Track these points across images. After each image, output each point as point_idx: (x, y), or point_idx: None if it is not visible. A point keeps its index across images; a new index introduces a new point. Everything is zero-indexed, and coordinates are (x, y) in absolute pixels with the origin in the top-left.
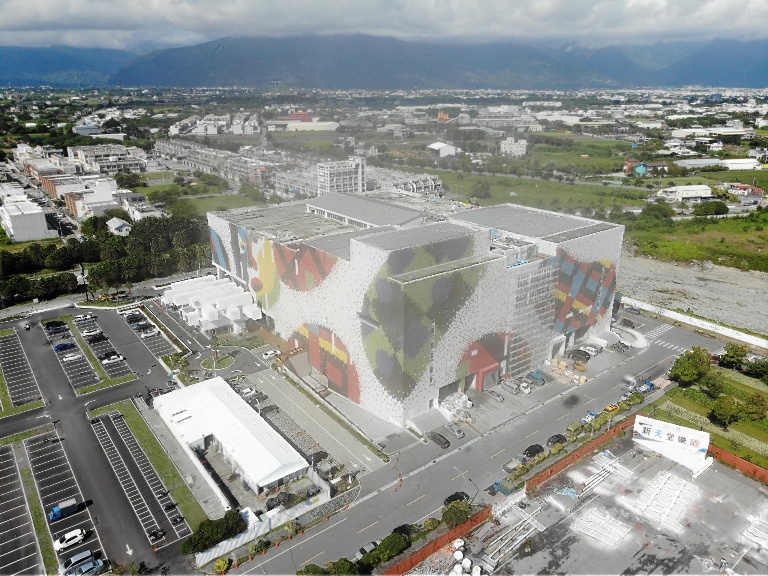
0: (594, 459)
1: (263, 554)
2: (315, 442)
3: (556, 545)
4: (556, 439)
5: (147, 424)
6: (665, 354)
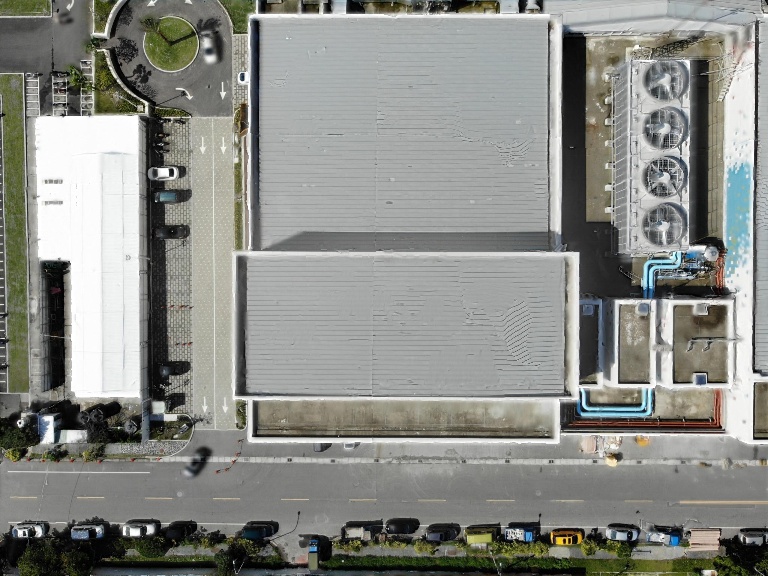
0: None
1: (55, 462)
2: (189, 337)
3: None
4: (436, 539)
5: (25, 159)
6: None
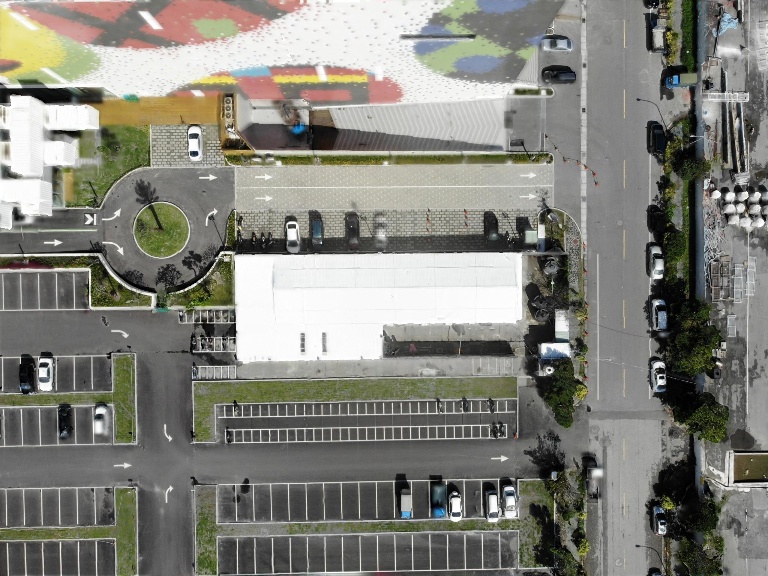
0: None
1: (588, 351)
2: (459, 213)
3: (766, 103)
4: None
5: (279, 381)
6: None
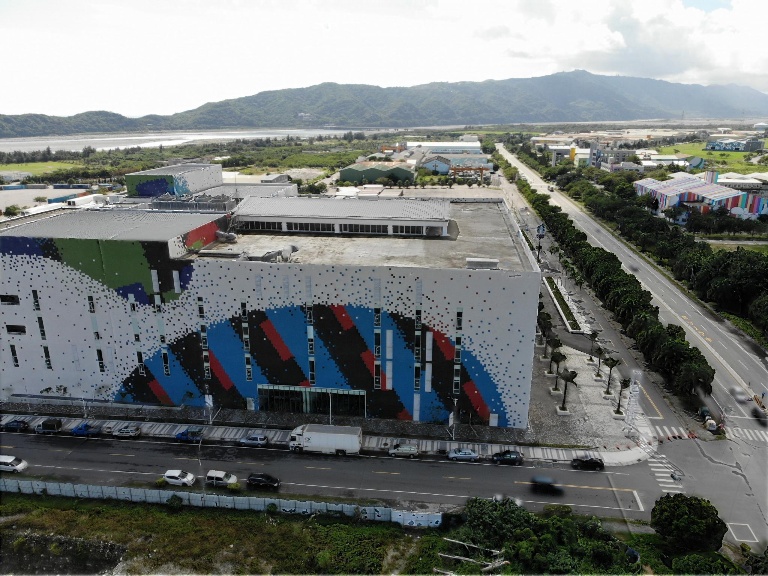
0: None
1: None
2: None
3: None
4: None
5: None
6: None
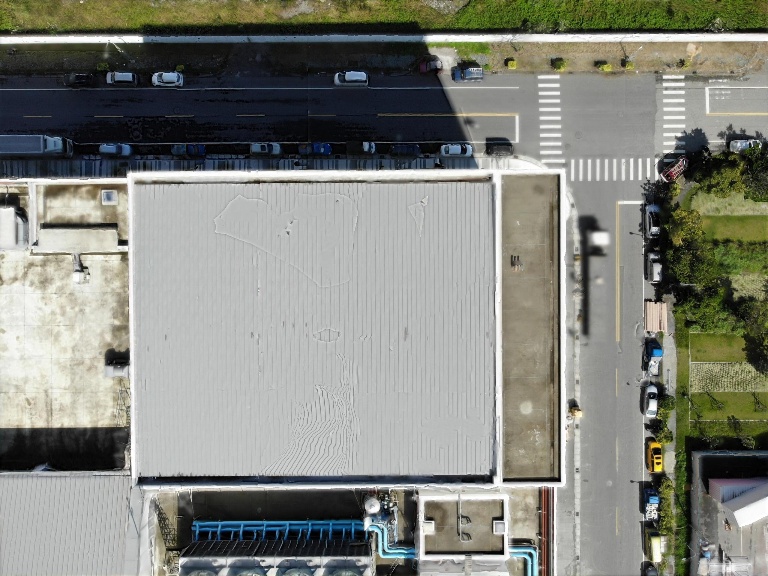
0: (703, 575)
1: None
2: None
3: None
4: None
5: None
6: (608, 211)
